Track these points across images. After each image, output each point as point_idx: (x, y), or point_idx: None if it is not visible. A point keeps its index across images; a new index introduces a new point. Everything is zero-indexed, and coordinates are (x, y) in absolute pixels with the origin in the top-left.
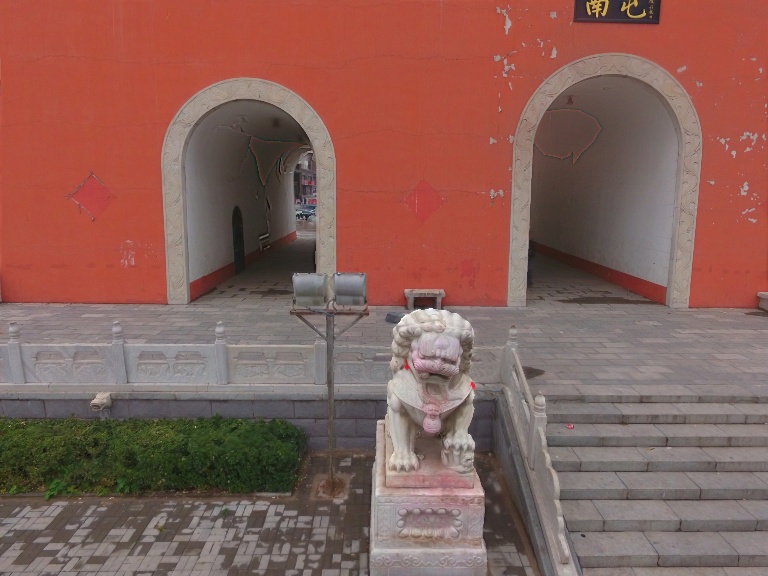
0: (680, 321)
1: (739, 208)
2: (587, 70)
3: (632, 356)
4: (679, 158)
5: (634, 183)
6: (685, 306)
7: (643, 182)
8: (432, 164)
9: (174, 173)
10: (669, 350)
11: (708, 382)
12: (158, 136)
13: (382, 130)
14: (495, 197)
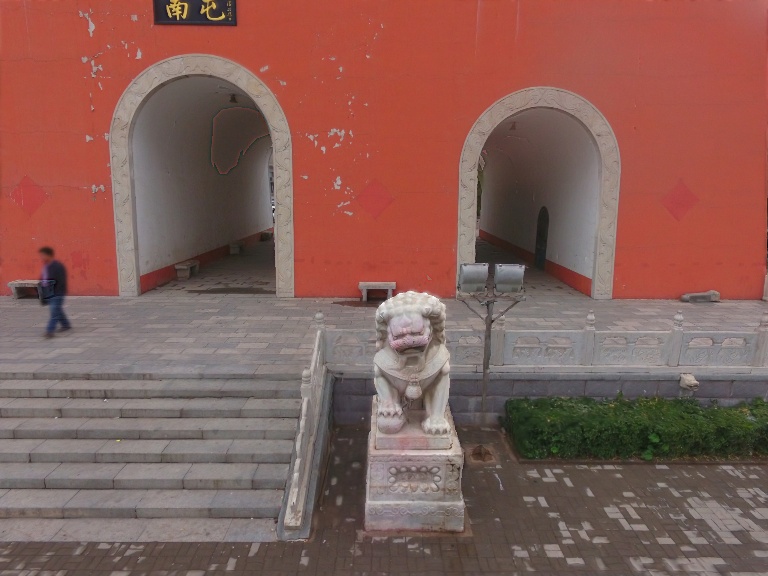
0: (243, 309)
1: (334, 202)
2: (172, 70)
3: (87, 339)
4: None
5: None
6: (291, 296)
7: None
8: (33, 161)
9: None
10: (140, 334)
11: (80, 361)
12: None
13: None
14: (96, 192)
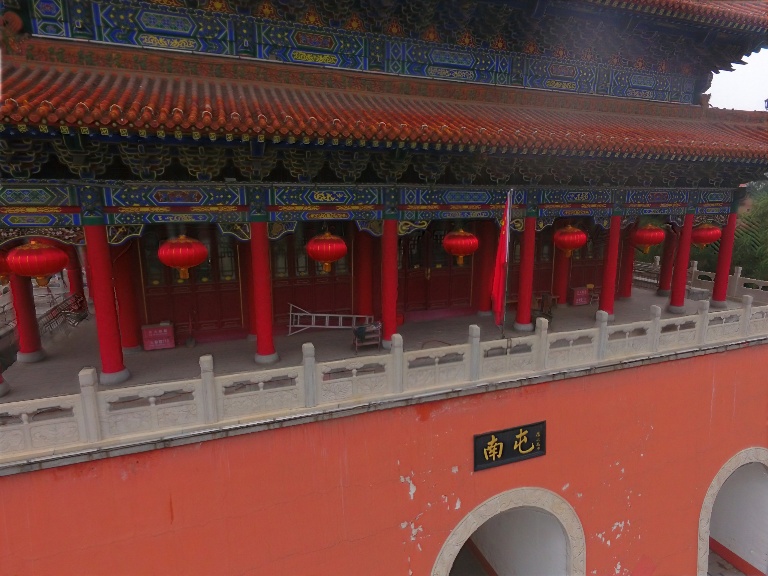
0: None
1: None
2: (489, 511)
3: None
4: (568, 558)
5: (522, 528)
6: None
7: (532, 538)
8: None
9: None
10: None
11: None
12: None
13: None
14: None
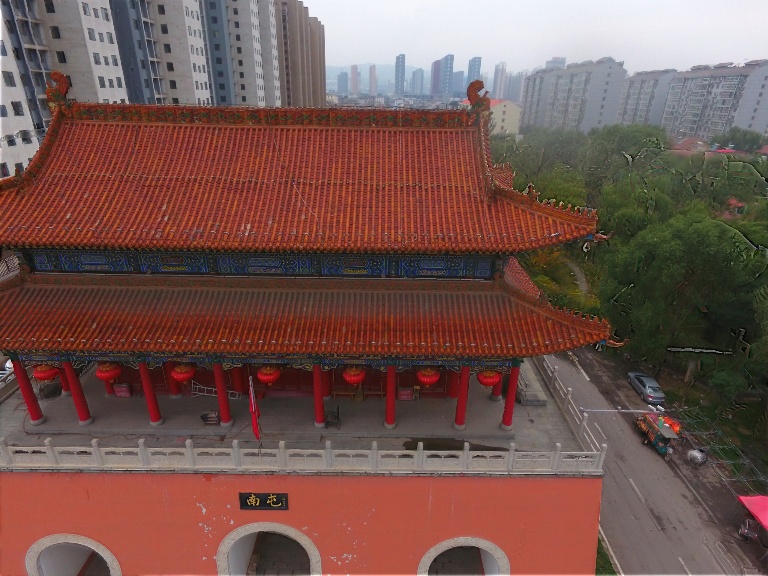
0: None
1: None
2: (251, 529)
3: None
4: None
5: None
6: None
7: None
8: (173, 568)
9: (34, 572)
10: None
11: None
12: (22, 556)
13: (143, 554)
14: None
